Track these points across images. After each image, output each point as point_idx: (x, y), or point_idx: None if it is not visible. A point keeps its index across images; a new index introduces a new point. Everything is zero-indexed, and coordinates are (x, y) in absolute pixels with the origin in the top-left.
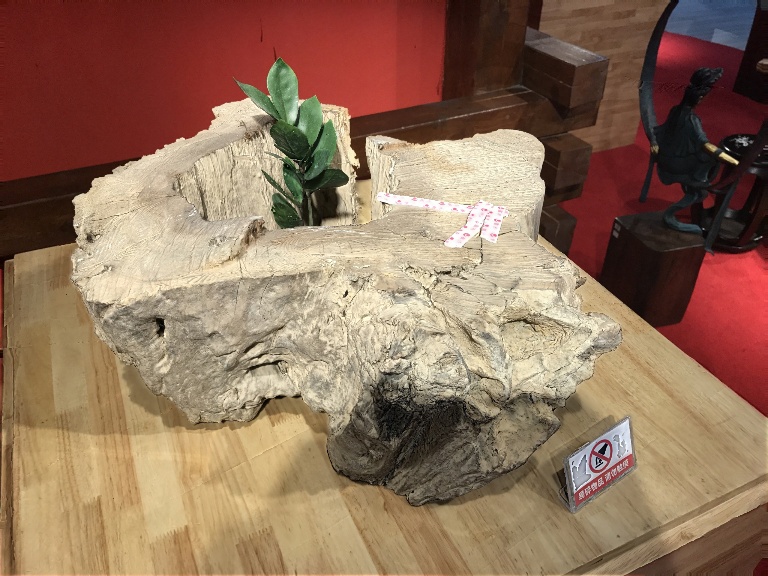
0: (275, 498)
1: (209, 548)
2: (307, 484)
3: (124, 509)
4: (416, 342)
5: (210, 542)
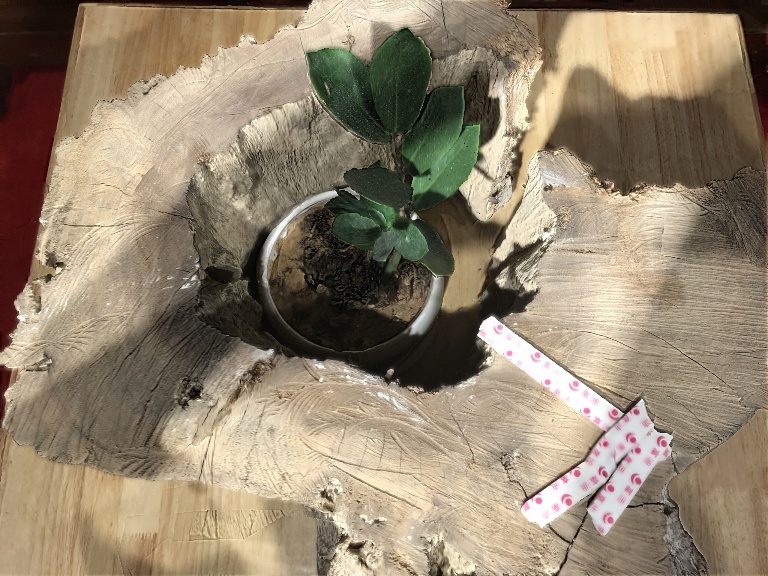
0: (250, 541)
1: (168, 571)
2: (288, 539)
3: (105, 481)
4: None
5: (171, 564)
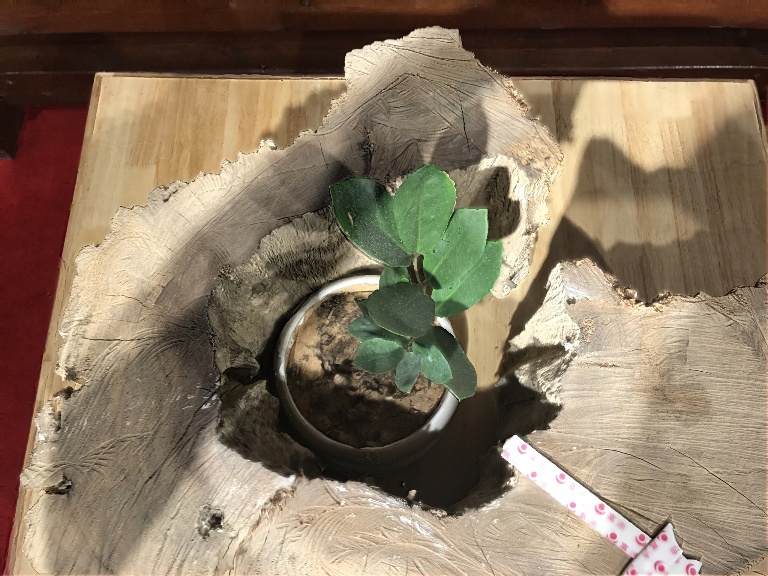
0: None
1: None
2: None
3: None
4: None
5: None
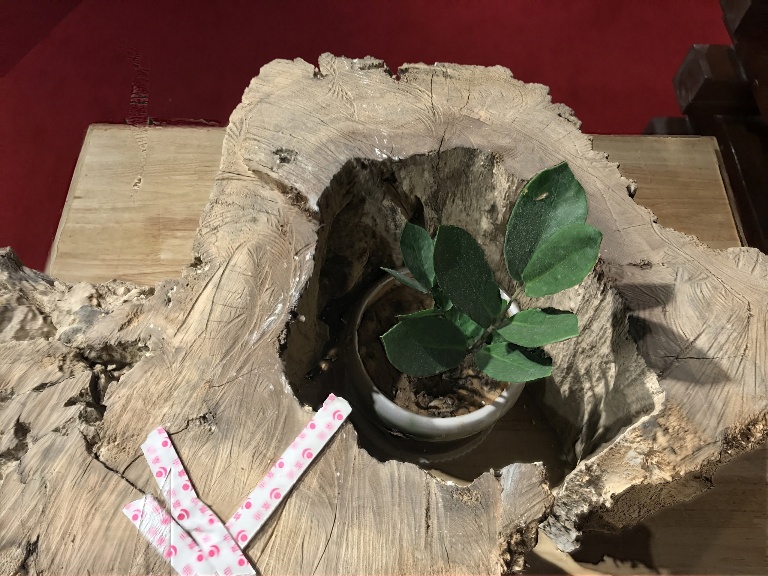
0: None
1: None
2: None
3: None
4: (7, 290)
5: None
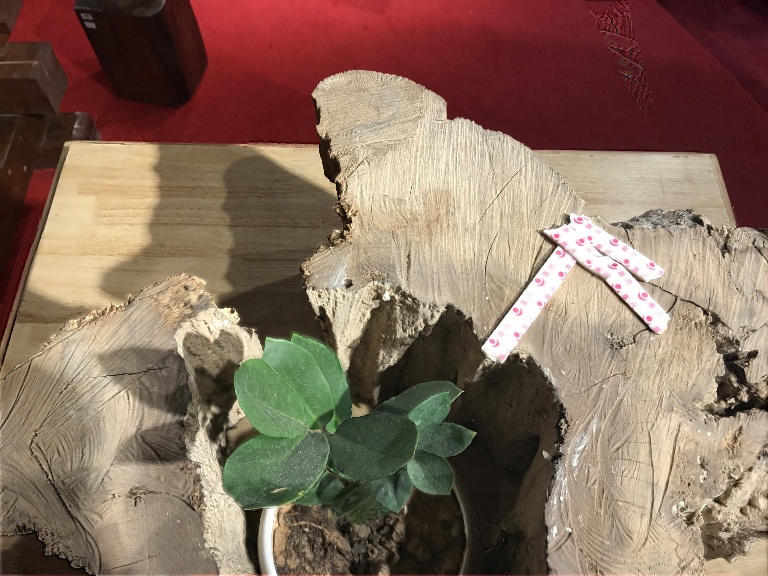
0: None
1: None
2: None
3: None
4: None
5: None
